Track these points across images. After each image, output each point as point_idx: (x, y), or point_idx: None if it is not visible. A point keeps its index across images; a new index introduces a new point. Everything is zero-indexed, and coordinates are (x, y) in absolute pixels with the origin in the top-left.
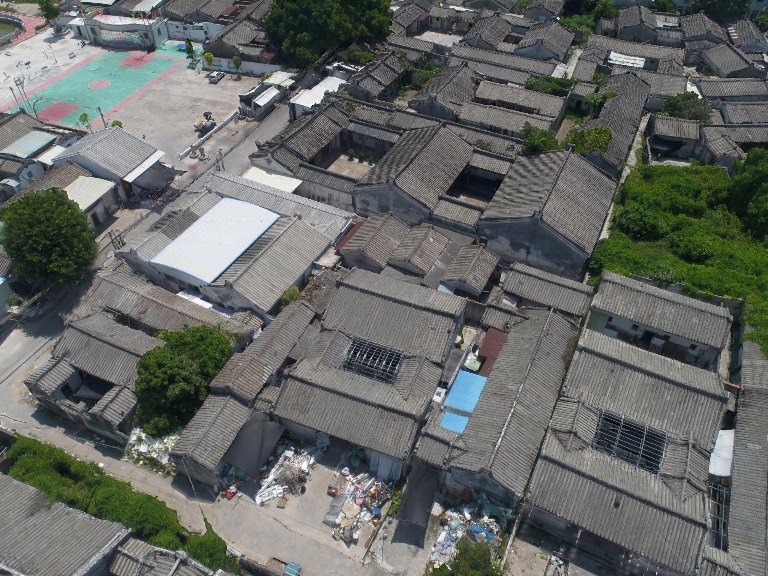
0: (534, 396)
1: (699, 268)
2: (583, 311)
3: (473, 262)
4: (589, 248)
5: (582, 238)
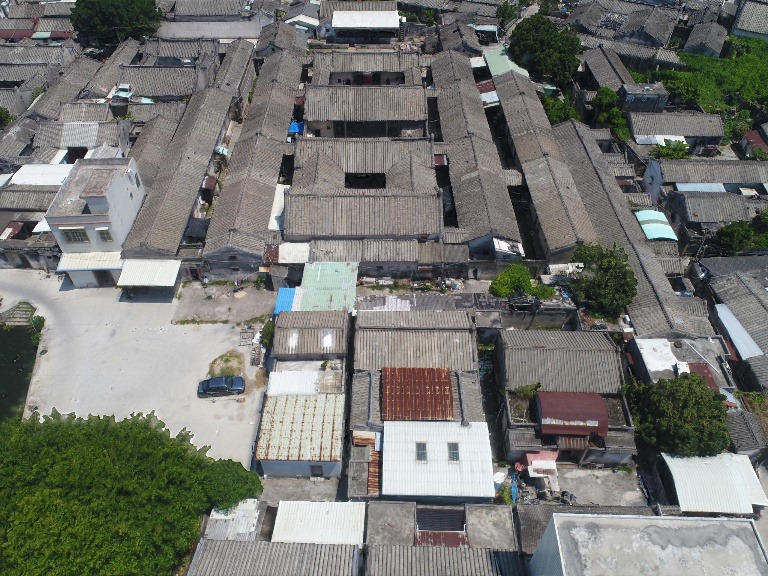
0: (625, 7)
1: (755, 57)
2: (689, 24)
3: (705, 2)
4: (743, 27)
5: (749, 24)
